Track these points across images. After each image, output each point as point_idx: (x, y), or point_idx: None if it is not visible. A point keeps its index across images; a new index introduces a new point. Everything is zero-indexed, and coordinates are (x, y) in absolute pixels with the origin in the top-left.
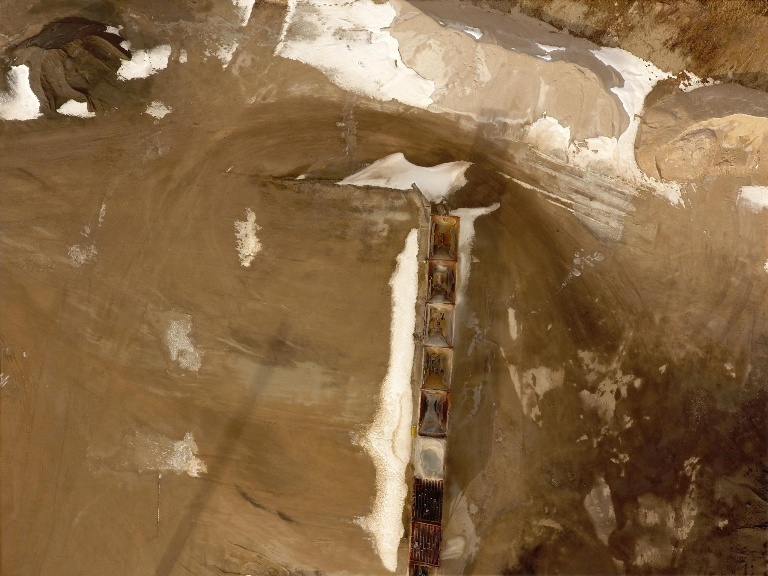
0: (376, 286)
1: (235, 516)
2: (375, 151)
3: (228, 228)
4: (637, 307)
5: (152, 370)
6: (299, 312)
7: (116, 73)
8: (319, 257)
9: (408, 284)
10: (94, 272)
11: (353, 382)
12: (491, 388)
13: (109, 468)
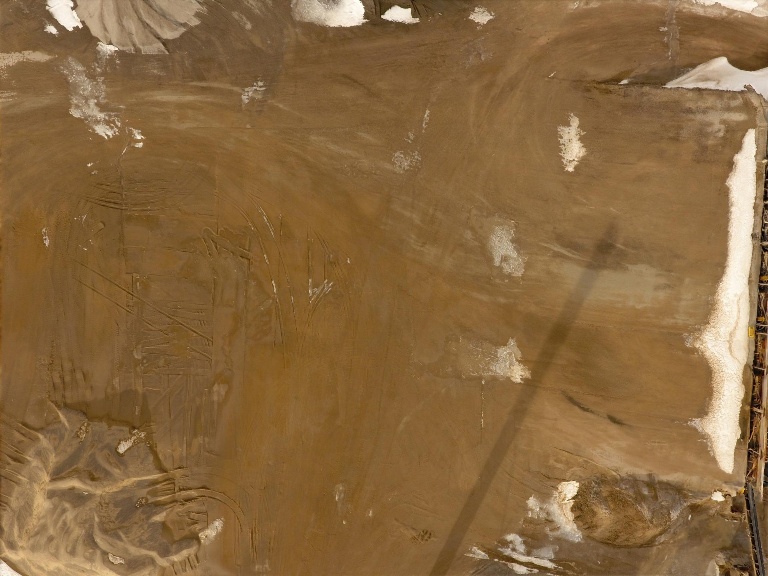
0: (713, 187)
1: (561, 421)
2: (698, 55)
3: (551, 133)
4: None
5: (476, 276)
6: (630, 215)
7: None
8: (651, 159)
9: (746, 184)
10: (418, 178)
11: (688, 284)
12: None
13: (433, 374)
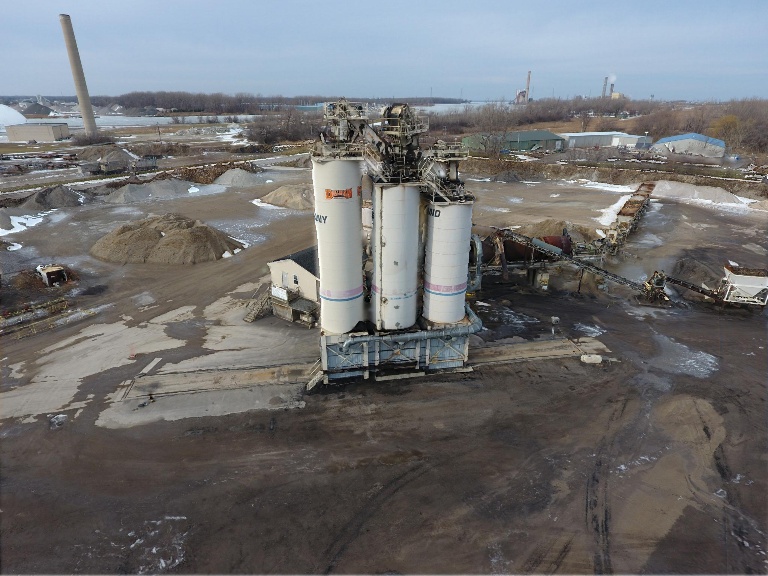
0: None
1: None
2: None
3: None
4: (762, 222)
5: None
6: (574, 198)
7: None
8: None
9: None
10: None
11: (596, 204)
12: None
13: None
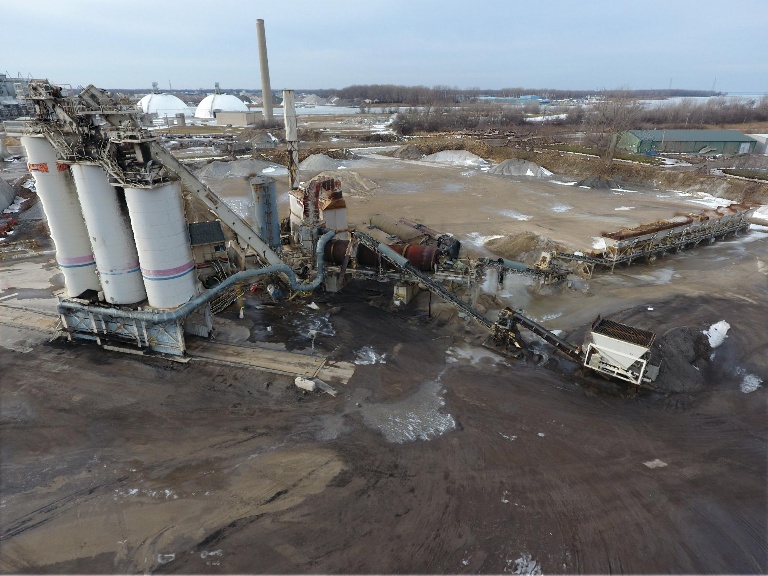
0: None
1: None
2: None
3: None
4: None
5: None
6: None
7: None
8: (659, 211)
9: None
10: None
11: None
12: (736, 260)
13: None
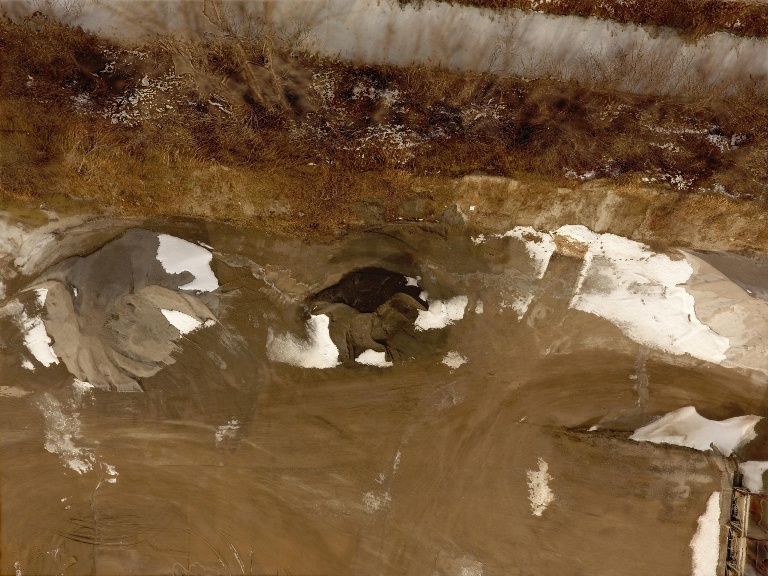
0: (677, 547)
1: None
2: (666, 404)
3: (520, 477)
4: None
5: None
6: (596, 567)
7: (414, 323)
8: (617, 514)
9: (710, 547)
10: (387, 518)
11: None
12: None
13: None
